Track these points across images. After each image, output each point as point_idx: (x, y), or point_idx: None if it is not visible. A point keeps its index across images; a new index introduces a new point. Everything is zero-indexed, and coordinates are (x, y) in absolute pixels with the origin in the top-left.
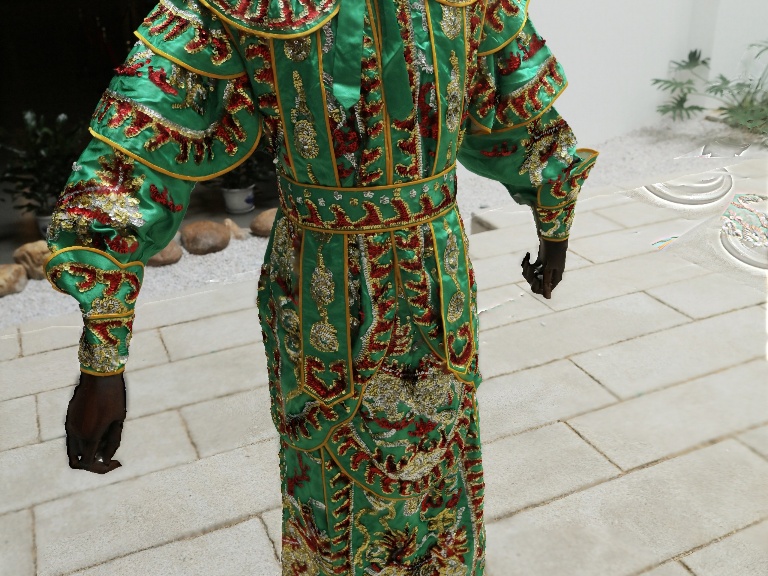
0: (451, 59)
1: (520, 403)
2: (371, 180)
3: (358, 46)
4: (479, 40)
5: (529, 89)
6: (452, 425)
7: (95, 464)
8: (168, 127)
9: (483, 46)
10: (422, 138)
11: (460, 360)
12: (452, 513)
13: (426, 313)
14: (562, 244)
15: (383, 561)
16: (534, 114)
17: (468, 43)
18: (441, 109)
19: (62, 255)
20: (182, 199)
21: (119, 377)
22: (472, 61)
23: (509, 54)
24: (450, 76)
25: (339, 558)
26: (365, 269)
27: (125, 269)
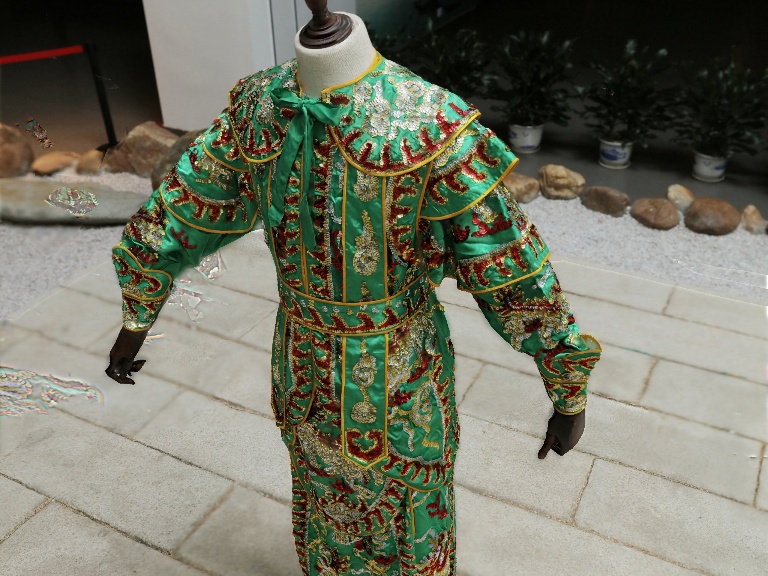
0: (363, 217)
1: (766, 556)
2: (295, 285)
3: (284, 184)
4: (421, 205)
5: (476, 263)
6: (373, 501)
7: (113, 375)
8: (191, 193)
9: (425, 211)
10: (335, 270)
11: (365, 455)
12: (380, 568)
13: (329, 403)
14: (566, 417)
15: (329, 562)
16: (479, 288)
17: (388, 208)
18: (346, 254)
19: (118, 249)
20: (197, 241)
21: (135, 334)
22: (394, 223)
23: (456, 226)
24: (363, 230)
25: (295, 535)
26: (290, 346)
27: (146, 272)
